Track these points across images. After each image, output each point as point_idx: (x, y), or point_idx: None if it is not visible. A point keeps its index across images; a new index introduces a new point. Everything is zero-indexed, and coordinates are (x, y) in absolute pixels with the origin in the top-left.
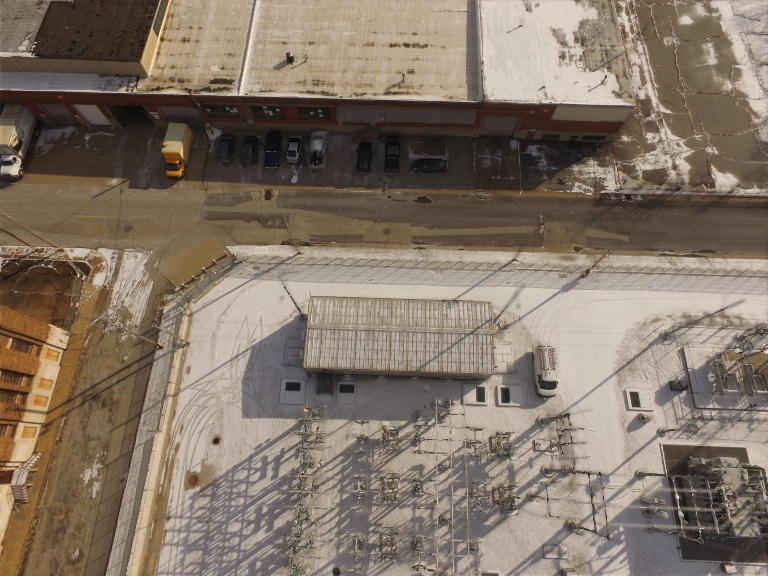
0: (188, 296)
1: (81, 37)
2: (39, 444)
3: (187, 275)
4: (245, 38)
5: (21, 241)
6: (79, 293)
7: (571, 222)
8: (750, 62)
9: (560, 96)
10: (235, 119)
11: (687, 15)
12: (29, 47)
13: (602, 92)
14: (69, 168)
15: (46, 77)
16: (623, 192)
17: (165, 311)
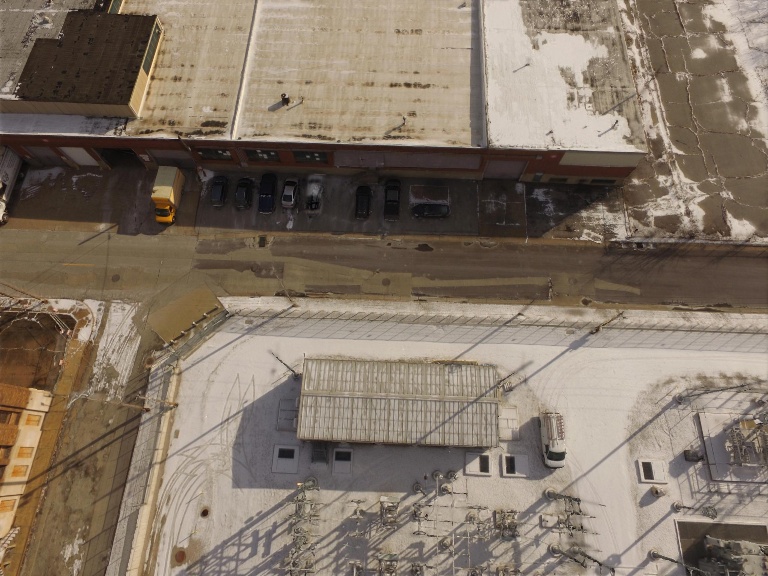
0: (177, 354)
1: (67, 78)
2: (18, 517)
3: (176, 329)
4: (239, 77)
5: (3, 294)
6: (63, 349)
7: (579, 273)
8: (766, 99)
9: (568, 142)
10: (228, 161)
11: (700, 48)
12: (13, 89)
13: (613, 137)
14: (55, 212)
15: (31, 119)
16: (634, 240)
17: (153, 369)
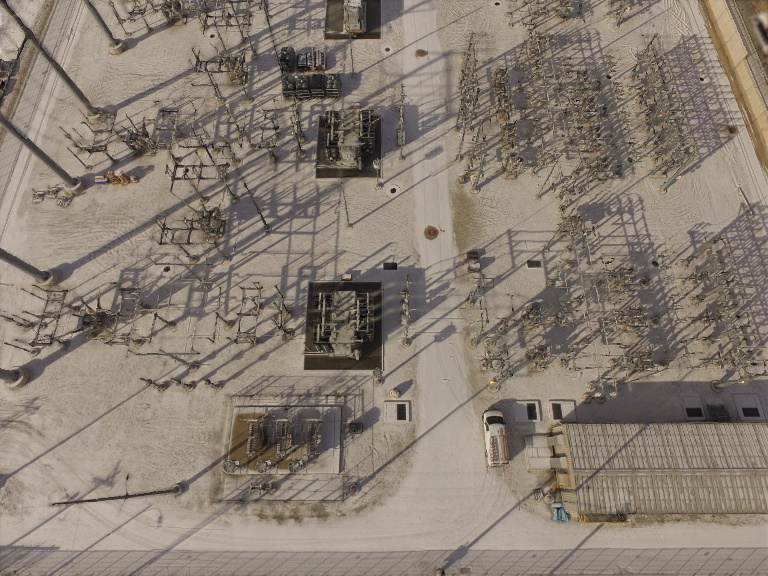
0: None
1: None
2: None
3: None
4: None
5: None
6: None
7: None
8: None
9: None
10: None
11: None
12: None
13: None
14: None
15: None
16: None
17: None
